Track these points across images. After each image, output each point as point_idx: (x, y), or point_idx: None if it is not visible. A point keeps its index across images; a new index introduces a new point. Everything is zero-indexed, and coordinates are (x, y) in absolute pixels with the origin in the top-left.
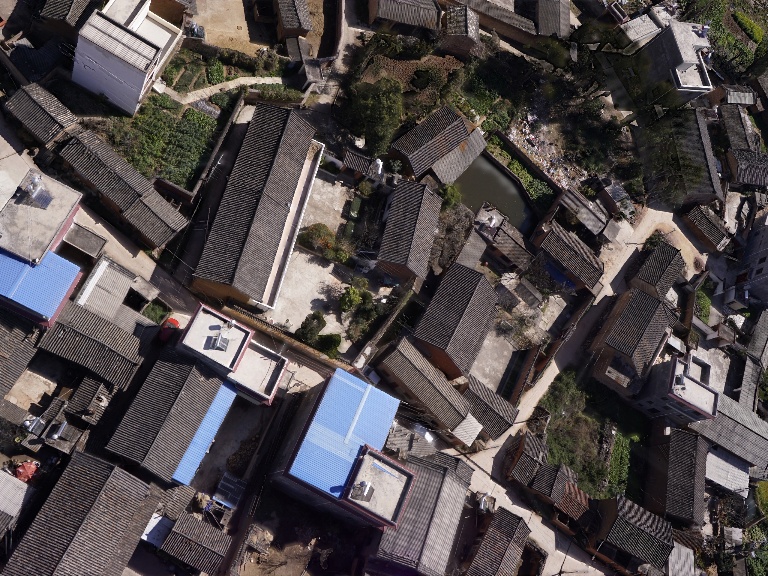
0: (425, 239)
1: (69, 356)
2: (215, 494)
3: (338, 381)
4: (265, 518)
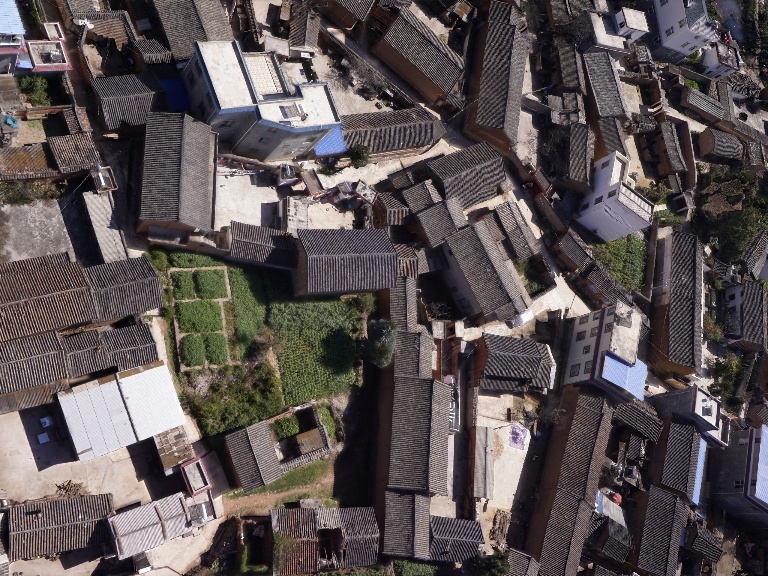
0: (765, 324)
1: (627, 422)
2: (696, 509)
3: (765, 433)
4: (719, 524)
